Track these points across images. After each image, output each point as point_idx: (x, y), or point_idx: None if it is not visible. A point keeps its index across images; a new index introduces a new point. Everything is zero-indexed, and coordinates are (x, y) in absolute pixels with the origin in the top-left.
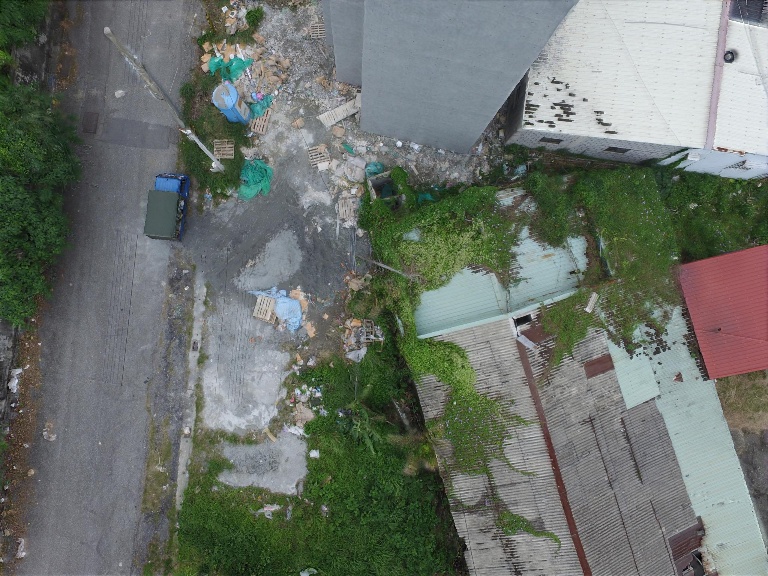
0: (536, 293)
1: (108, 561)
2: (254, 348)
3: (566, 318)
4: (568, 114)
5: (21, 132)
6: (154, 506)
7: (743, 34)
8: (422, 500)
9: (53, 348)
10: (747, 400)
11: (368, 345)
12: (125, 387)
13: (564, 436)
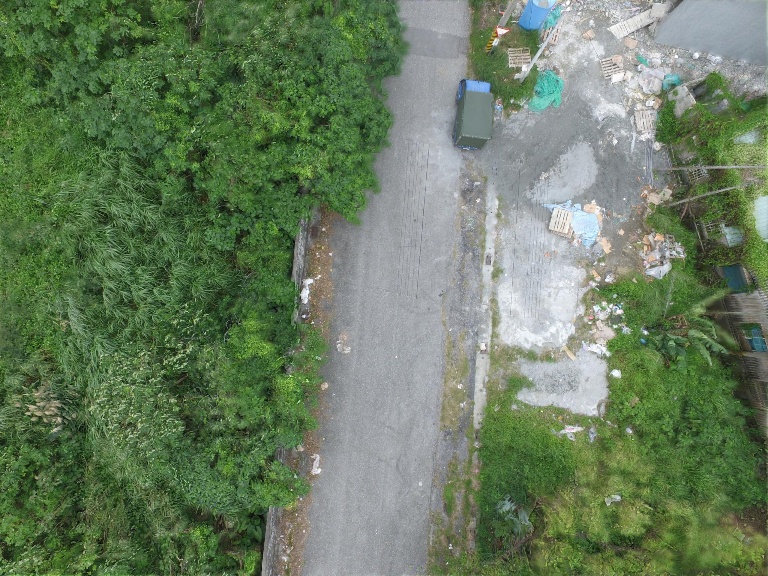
0: None
1: (408, 480)
2: (550, 263)
3: None
4: None
5: (373, 16)
6: (452, 424)
7: None
8: None
9: (345, 258)
10: None
11: (671, 261)
12: (420, 300)
13: None
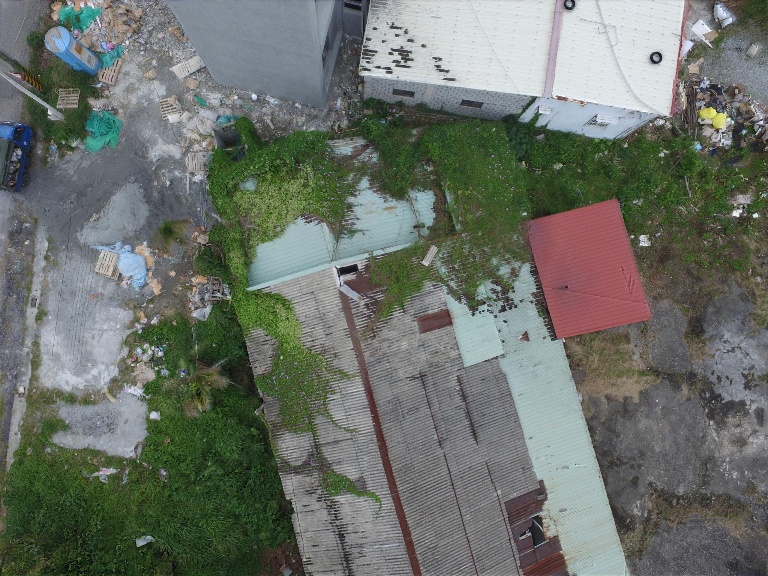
0: (373, 246)
1: None
2: (96, 305)
3: (398, 270)
4: (406, 60)
5: None
6: None
7: None
8: (267, 465)
9: None
10: (611, 366)
11: (214, 303)
12: None
13: (388, 391)
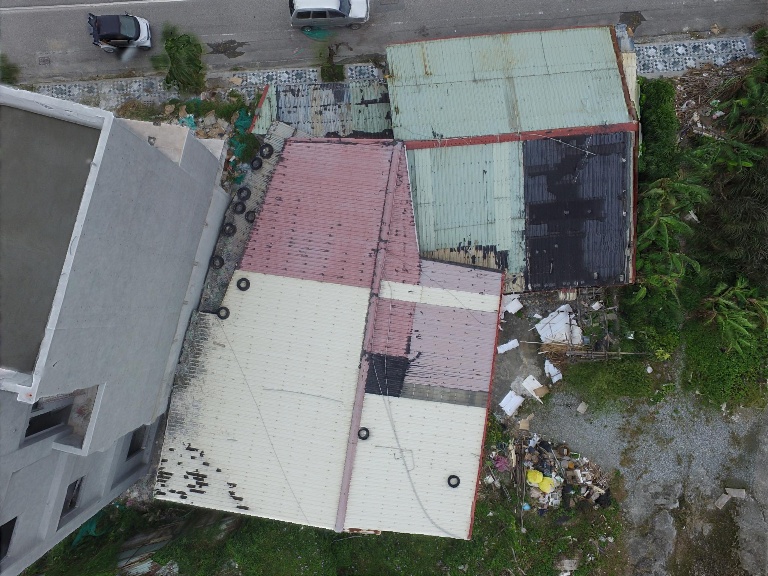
0: None
1: None
2: None
3: None
4: (200, 485)
5: None
6: None
7: (381, 407)
8: None
9: None
10: None
11: None
12: None
13: None
